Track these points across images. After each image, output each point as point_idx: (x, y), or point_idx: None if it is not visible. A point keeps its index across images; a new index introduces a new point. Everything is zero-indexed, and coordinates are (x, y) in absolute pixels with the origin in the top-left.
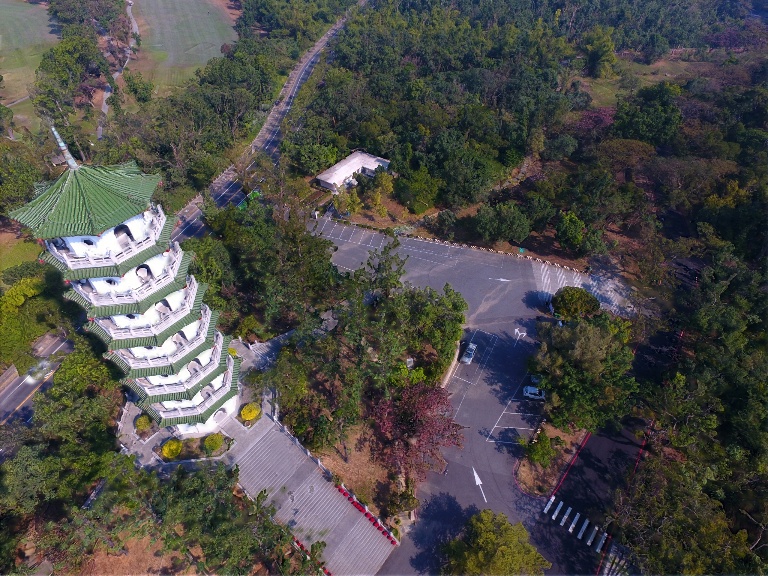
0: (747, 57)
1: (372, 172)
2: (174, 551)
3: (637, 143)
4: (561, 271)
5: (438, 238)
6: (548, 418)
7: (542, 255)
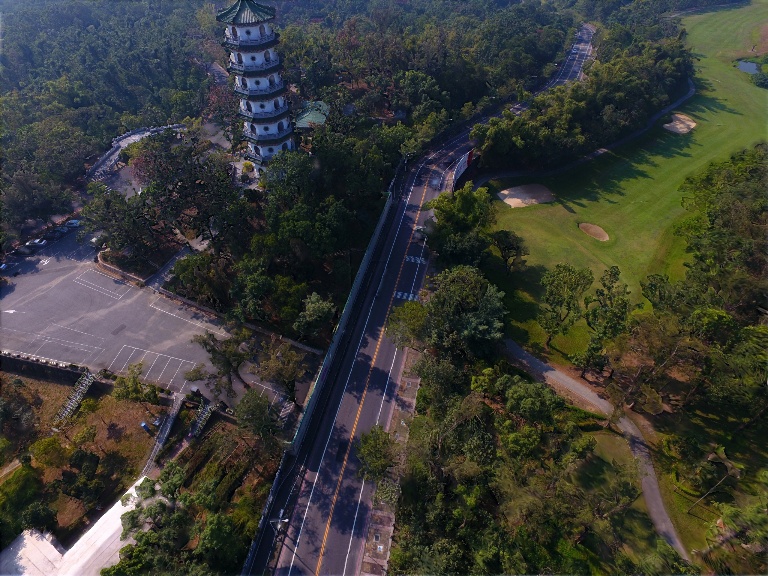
0: None
1: None
2: None
3: None
4: None
5: (33, 407)
6: (76, 216)
7: None
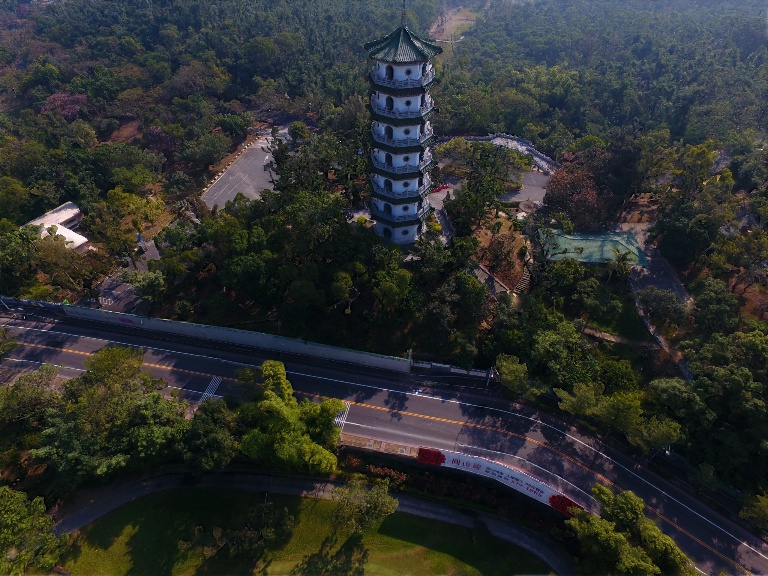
0: (4, 43)
1: (70, 222)
2: (483, 229)
3: (131, 90)
4: (260, 141)
5: None
6: None
7: (236, 150)
